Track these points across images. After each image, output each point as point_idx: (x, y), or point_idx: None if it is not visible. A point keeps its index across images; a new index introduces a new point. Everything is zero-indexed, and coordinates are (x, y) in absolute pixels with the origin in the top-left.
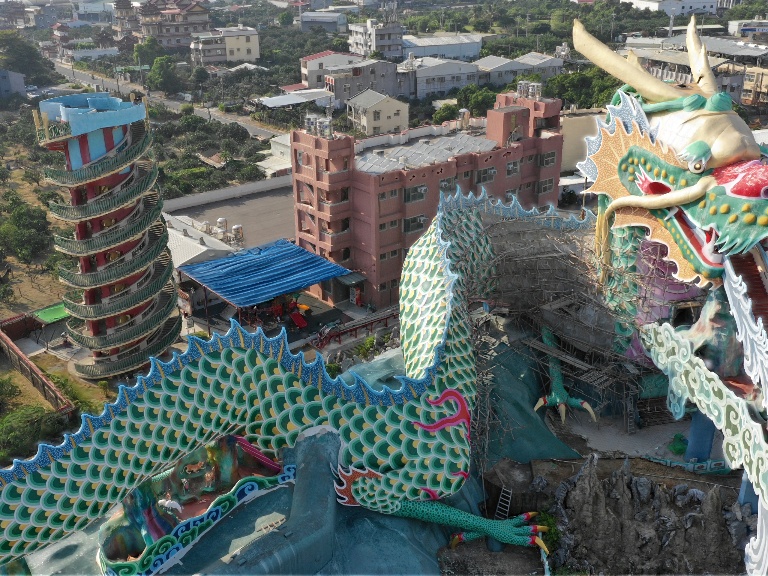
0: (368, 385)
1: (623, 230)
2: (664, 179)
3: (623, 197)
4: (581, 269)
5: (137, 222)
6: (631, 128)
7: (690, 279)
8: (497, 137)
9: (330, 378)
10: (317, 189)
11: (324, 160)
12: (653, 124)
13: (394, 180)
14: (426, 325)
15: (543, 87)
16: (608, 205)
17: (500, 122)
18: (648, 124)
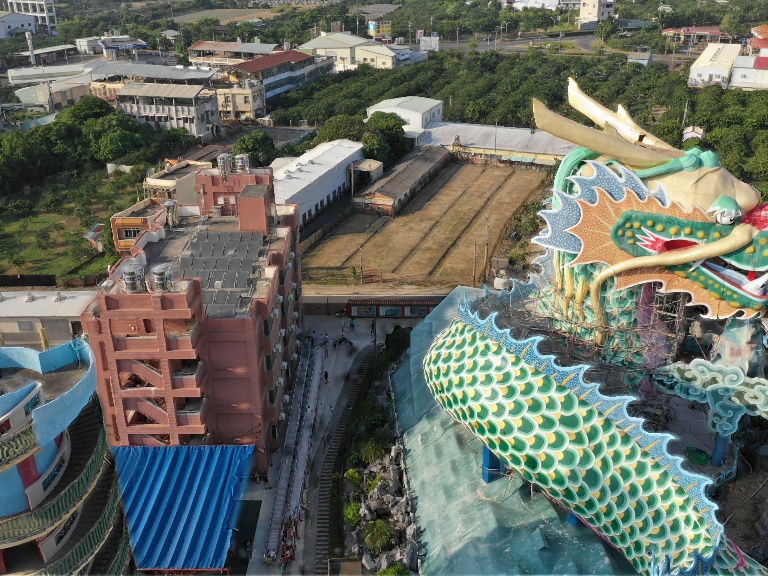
0: (703, 558)
1: (620, 290)
2: (688, 236)
3: (628, 261)
4: (554, 339)
5: (124, 533)
6: (618, 195)
7: (729, 315)
8: (259, 226)
9: (672, 575)
10: (168, 362)
11: (142, 320)
12: (653, 188)
13: (254, 314)
14: (614, 463)
15: (26, 145)
16: (596, 271)
17: (261, 208)
18: (647, 189)
